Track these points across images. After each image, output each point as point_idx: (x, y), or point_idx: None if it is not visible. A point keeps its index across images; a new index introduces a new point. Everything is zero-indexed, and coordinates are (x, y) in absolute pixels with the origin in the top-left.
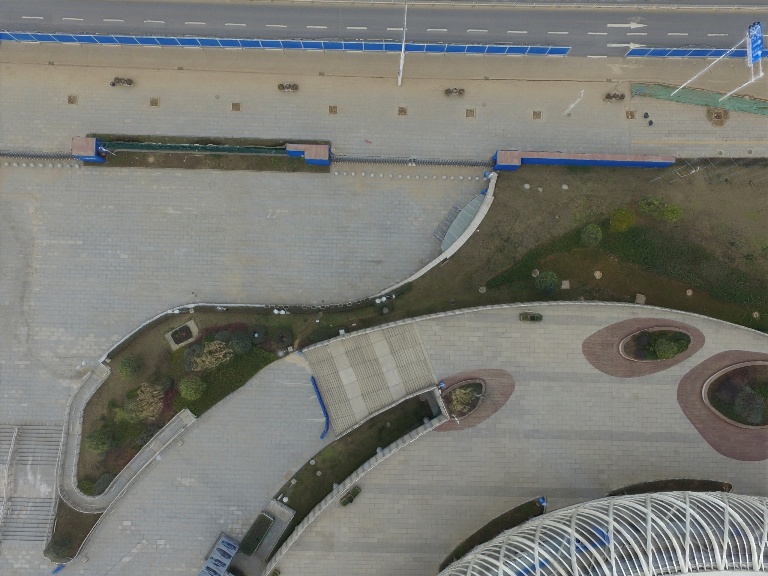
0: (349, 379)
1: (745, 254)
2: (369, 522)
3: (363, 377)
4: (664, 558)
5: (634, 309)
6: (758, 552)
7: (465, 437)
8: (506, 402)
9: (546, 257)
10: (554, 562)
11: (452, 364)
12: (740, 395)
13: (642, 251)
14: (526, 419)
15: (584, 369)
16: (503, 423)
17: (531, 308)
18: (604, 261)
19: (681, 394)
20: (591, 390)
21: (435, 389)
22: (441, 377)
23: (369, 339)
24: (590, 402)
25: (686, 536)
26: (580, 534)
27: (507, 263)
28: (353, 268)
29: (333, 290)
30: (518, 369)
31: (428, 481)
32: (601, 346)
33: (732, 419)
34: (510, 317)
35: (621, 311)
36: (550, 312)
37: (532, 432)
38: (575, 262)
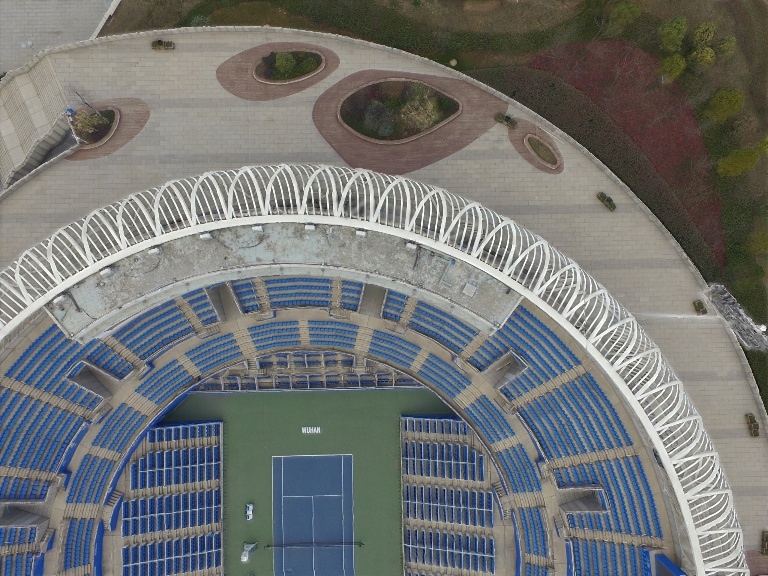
0: (8, 131)
1: (412, 1)
2: (7, 251)
3: (19, 126)
4: (207, 205)
5: (267, 34)
6: (302, 196)
7: (101, 165)
8: (141, 129)
9: (212, 12)
10: (101, 217)
11: (86, 95)
12: (369, 109)
13: (309, 2)
14: (162, 145)
15: (219, 94)
16: (139, 150)
17: (164, 37)
18: (273, 15)
19: (316, 115)
20: (226, 114)
21: (65, 116)
22: (76, 108)
23: (16, 83)
24: (225, 126)
25: (231, 185)
26: (136, 196)
27: (172, 18)
28: (33, 40)
29: (13, 62)
30: (153, 97)
31: (65, 209)
32: (235, 71)
33: (365, 135)
34: (143, 47)
35: (255, 37)
36: (184, 41)
37: (168, 157)
38: (243, 16)
